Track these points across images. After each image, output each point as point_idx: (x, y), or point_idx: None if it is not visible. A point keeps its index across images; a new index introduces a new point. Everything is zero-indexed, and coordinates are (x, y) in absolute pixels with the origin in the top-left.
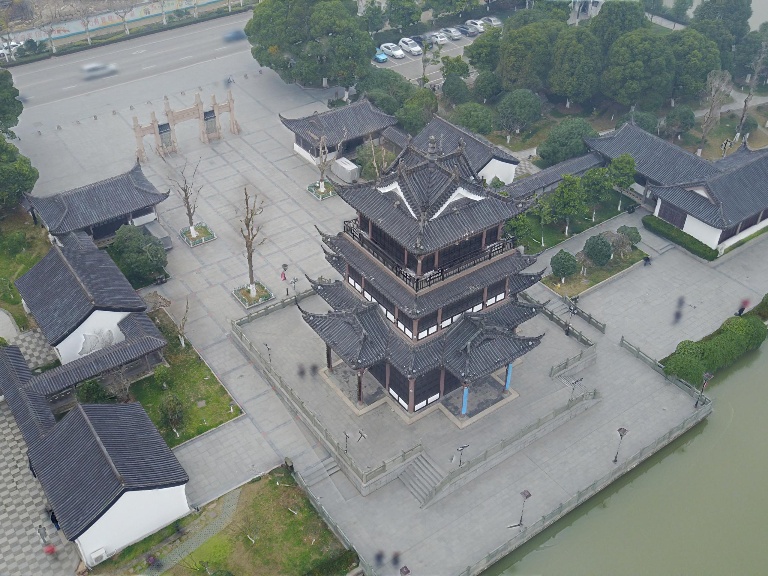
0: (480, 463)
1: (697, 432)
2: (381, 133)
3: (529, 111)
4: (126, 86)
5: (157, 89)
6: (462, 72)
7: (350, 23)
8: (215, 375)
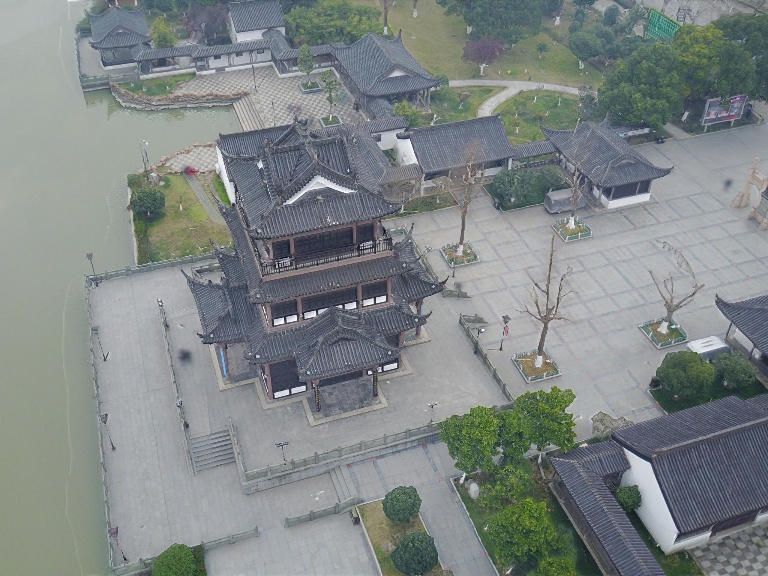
0: None
1: None
2: None
3: None
4: None
5: None
6: None
7: None
8: None
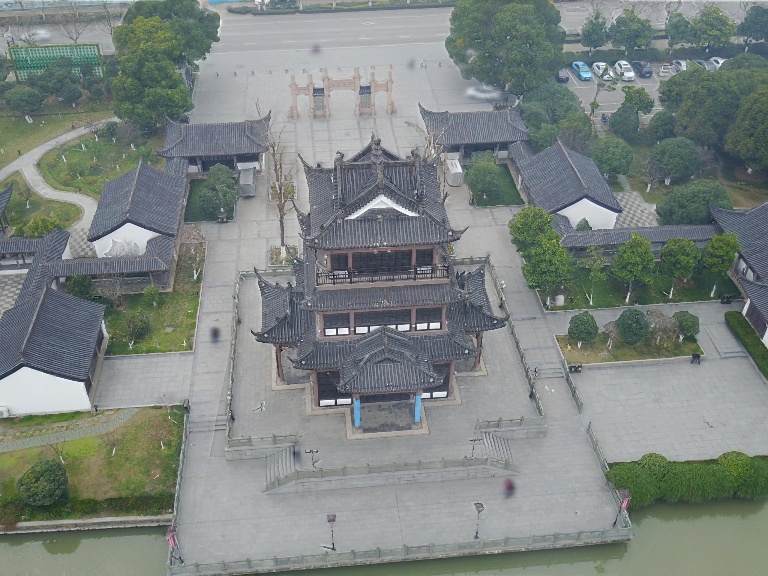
0: (337, 476)
1: (612, 555)
2: (508, 145)
3: (678, 163)
4: (333, 51)
5: (356, 59)
6: (640, 106)
7: (532, 30)
8: (198, 311)
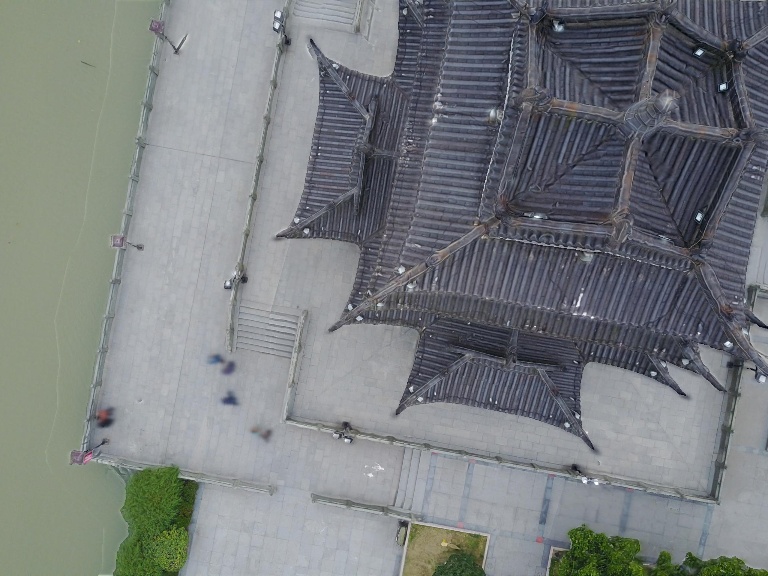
0: None
1: None
2: None
3: None
4: None
5: None
6: None
7: None
8: None
